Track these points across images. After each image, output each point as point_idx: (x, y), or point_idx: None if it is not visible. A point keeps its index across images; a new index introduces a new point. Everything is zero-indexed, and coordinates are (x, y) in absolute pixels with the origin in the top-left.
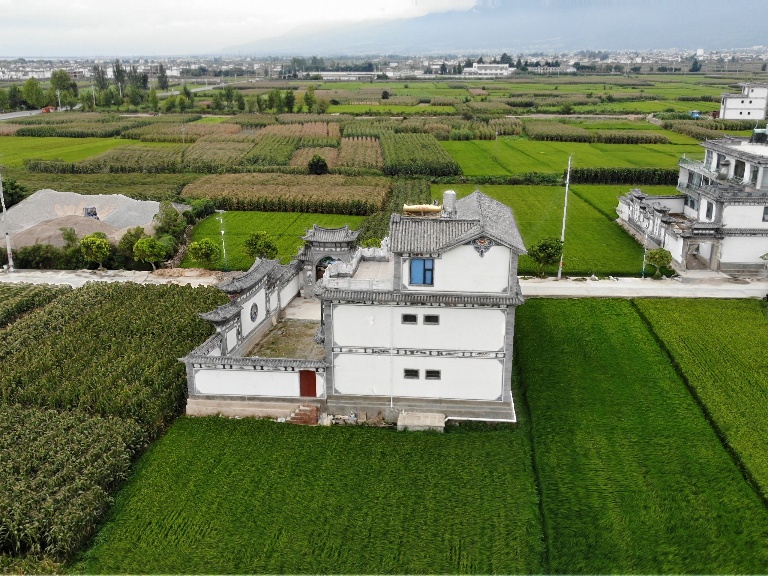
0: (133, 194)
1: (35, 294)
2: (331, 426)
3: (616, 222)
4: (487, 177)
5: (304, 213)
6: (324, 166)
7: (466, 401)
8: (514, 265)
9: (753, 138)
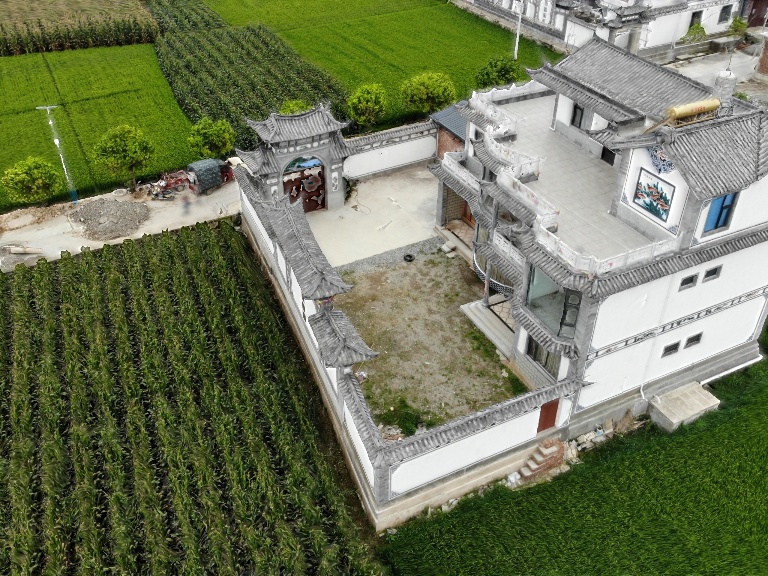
0: None
1: None
2: (584, 457)
3: (453, 5)
4: None
5: (46, 53)
6: None
7: (717, 355)
8: None
9: None
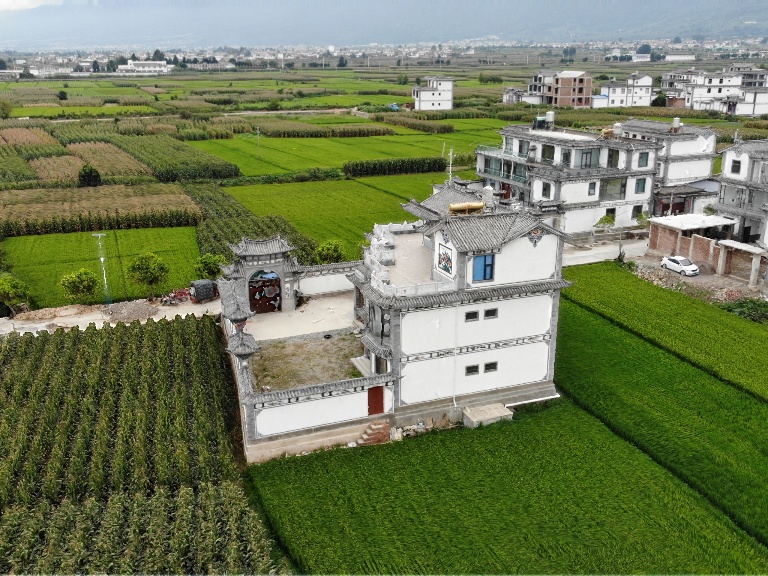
0: None
1: None
2: (406, 439)
3: None
4: (273, 176)
5: (117, 230)
6: (97, 177)
7: (518, 386)
8: (560, 251)
9: (536, 125)
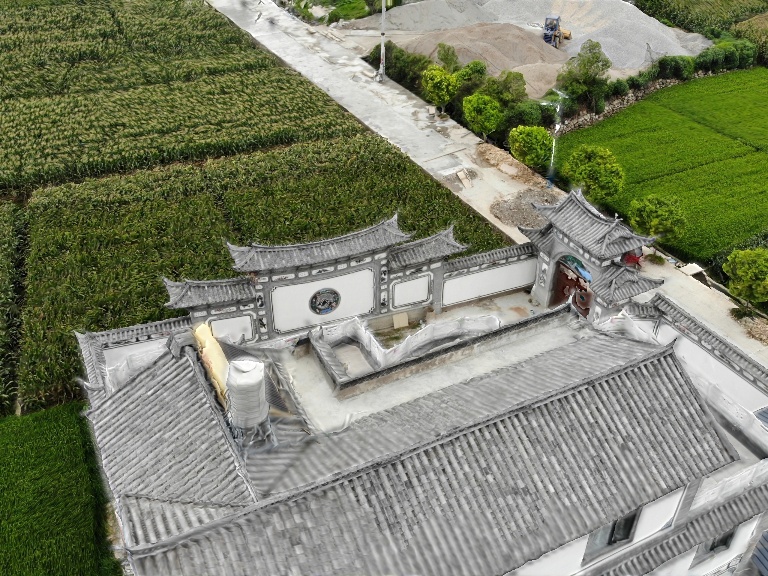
0: (677, 5)
1: (311, 126)
2: (127, 575)
3: None
4: None
5: None
6: None
7: None
8: None
9: None
